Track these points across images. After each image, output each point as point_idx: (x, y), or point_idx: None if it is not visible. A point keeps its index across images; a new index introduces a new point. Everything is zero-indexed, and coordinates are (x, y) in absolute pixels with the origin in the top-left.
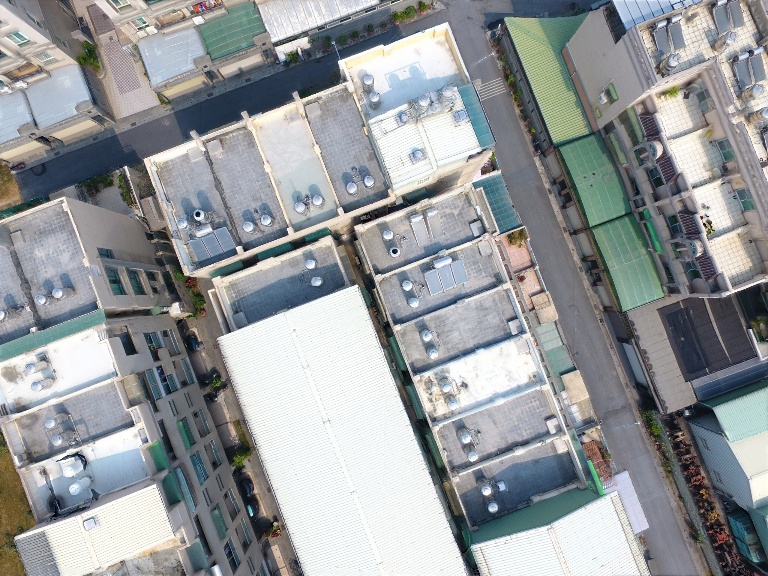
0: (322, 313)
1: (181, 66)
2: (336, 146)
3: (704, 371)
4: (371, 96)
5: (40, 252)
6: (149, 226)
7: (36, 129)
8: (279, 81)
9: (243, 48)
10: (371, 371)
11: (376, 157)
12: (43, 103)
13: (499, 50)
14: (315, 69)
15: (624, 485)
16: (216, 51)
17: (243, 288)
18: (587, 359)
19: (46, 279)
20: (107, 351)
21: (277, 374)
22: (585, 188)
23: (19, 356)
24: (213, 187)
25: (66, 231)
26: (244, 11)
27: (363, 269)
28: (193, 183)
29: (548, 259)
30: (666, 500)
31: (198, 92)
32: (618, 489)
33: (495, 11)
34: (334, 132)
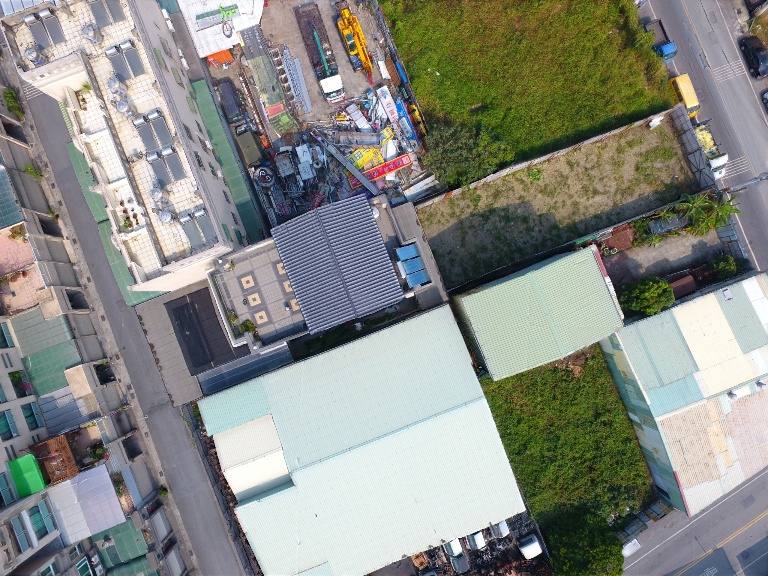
0: None
1: None
2: None
3: (209, 365)
4: None
5: None
6: None
7: None
8: None
9: None
10: None
11: None
12: None
13: None
14: None
15: (100, 479)
16: None
17: None
18: (134, 354)
19: None
20: None
21: None
22: (87, 183)
23: None
24: None
25: None
26: None
27: None
28: None
29: (97, 255)
30: (209, 494)
31: None
32: (94, 483)
33: None
34: None
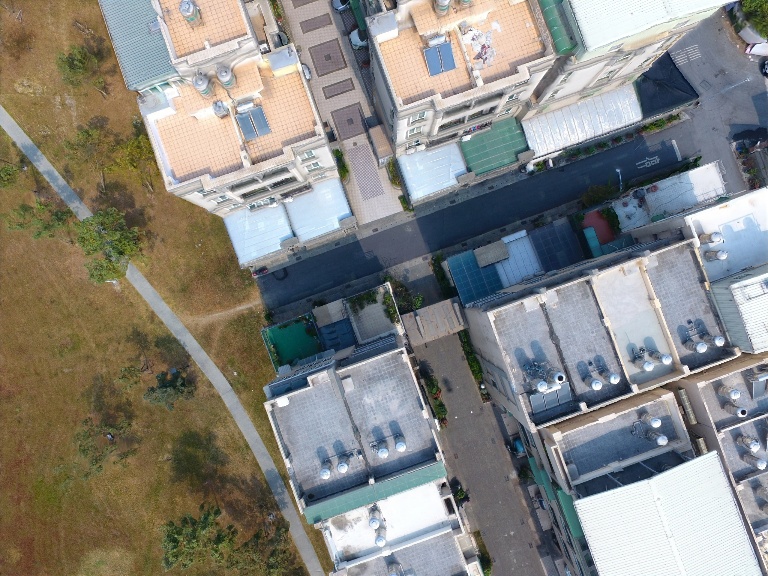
0: (684, 481)
1: (443, 181)
2: (671, 298)
3: None
4: (720, 254)
5: (369, 398)
6: (410, 342)
7: (298, 242)
8: (522, 189)
9: (505, 164)
10: (731, 540)
11: (714, 312)
12: (304, 216)
13: (746, 163)
14: (558, 178)
15: None
16: (478, 166)
17: (573, 439)
18: None
19: (375, 426)
20: (437, 500)
21: (638, 542)
22: None
23: (359, 508)
24: (547, 337)
25: (395, 377)
26: (507, 127)
27: (687, 419)
28: (526, 333)
29: None
30: None
31: (441, 199)
32: None
33: (740, 122)
34: (669, 284)
